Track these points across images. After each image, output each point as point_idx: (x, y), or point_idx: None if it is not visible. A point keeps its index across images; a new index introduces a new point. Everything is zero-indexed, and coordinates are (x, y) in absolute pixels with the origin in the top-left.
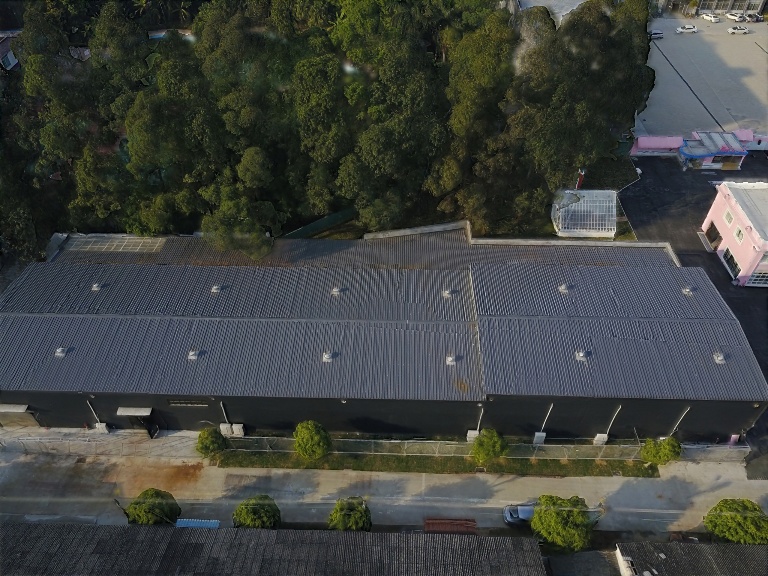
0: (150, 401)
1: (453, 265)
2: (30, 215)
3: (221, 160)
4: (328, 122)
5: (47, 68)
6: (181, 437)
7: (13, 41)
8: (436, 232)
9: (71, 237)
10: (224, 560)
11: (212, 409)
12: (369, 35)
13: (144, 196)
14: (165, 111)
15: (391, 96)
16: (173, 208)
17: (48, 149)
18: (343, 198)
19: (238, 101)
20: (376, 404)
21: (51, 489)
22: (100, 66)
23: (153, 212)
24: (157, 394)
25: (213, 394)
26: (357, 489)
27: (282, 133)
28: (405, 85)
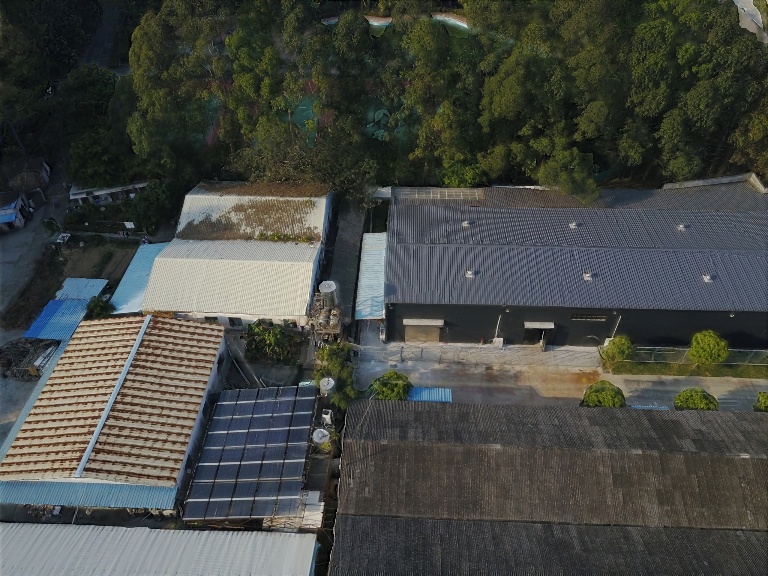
0: (553, 316)
1: (759, 210)
2: (377, 165)
3: (559, 114)
4: (658, 80)
5: (431, 30)
6: (567, 351)
7: (396, 7)
8: (724, 184)
9: (395, 188)
10: (707, 431)
11: (607, 324)
12: (705, 1)
13: (460, 151)
14: (533, 68)
15: (718, 56)
16: (507, 158)
17: (409, 104)
18: (651, 151)
19: (591, 59)
20: (760, 318)
21: (477, 390)
22: (474, 28)
23: (495, 161)
24: (572, 307)
25: (622, 307)
26: (745, 392)
27: (616, 90)
28: (730, 46)
